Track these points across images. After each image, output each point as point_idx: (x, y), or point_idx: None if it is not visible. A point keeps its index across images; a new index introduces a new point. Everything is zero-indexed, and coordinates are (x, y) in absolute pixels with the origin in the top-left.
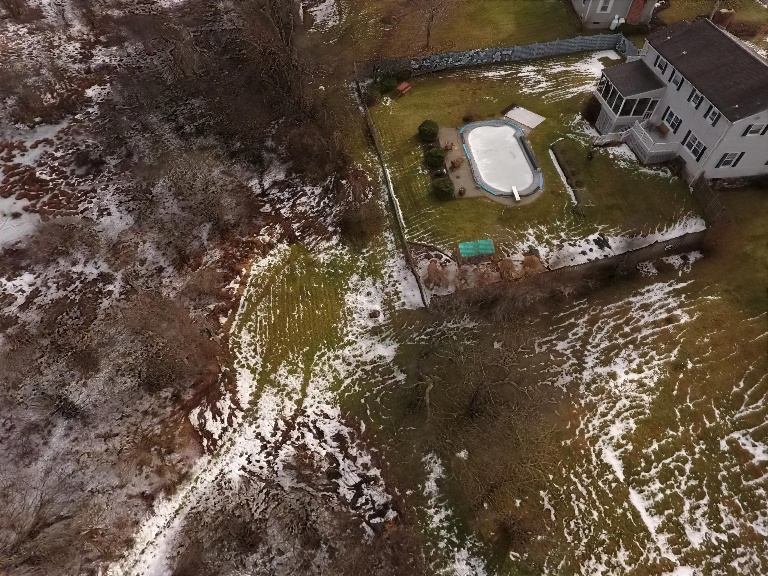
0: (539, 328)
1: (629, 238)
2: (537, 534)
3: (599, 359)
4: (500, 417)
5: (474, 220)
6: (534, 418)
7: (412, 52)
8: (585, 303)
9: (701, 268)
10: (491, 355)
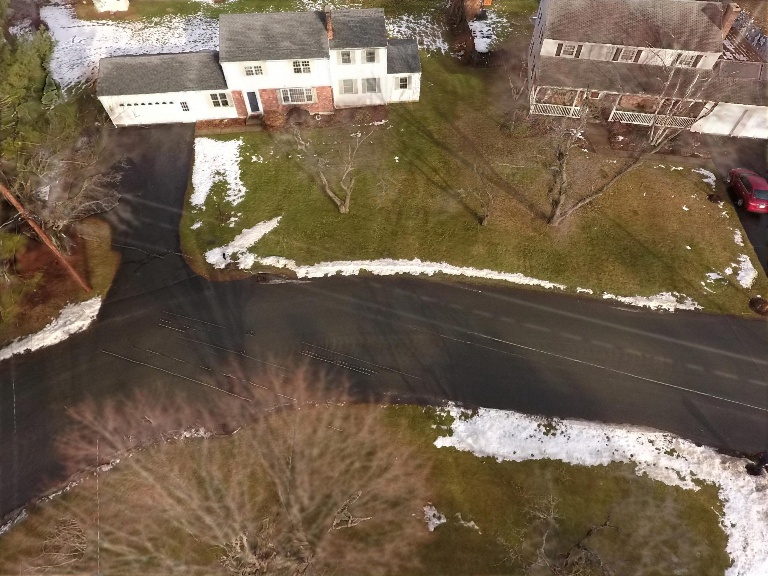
0: (437, 18)
1: (487, 43)
2: (348, 1)
3: (410, 26)
4: (396, 3)
5: (518, 5)
6: (391, 8)
7: (766, 19)
8: (446, 29)
9: (452, 59)
10: (428, 7)
